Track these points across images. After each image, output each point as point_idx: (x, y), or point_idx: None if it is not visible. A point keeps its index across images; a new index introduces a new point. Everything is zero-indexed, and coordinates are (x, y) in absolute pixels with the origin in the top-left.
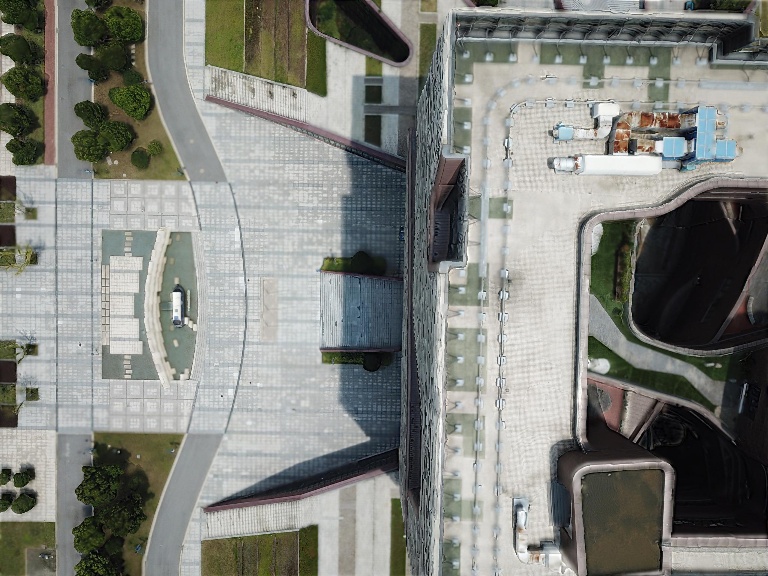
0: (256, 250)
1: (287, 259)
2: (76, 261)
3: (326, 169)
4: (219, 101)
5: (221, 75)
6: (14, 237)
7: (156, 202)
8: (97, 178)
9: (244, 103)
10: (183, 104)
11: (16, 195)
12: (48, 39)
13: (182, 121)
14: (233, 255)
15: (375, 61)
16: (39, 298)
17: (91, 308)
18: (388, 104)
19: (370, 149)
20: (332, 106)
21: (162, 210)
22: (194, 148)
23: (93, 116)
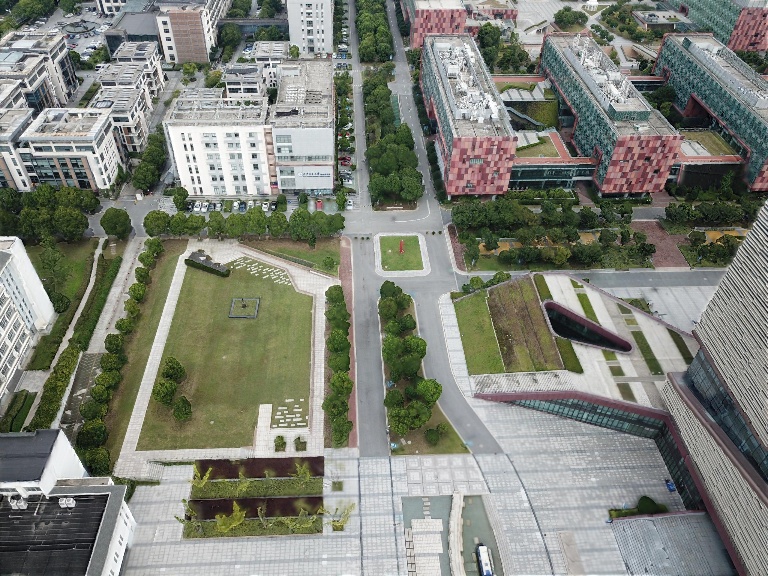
0: (544, 507)
1: (575, 513)
2: (380, 526)
3: (584, 439)
4: (487, 395)
5: (485, 379)
6: (322, 506)
7: (447, 471)
8: (394, 455)
9: (511, 391)
10: (457, 400)
11: (324, 472)
12: (349, 366)
13: (458, 412)
14: (524, 513)
15: (609, 352)
16: (345, 564)
17: (397, 571)
18: (630, 376)
19: (630, 404)
20: (589, 379)
21: (453, 478)
22: (471, 430)
23: (400, 401)
